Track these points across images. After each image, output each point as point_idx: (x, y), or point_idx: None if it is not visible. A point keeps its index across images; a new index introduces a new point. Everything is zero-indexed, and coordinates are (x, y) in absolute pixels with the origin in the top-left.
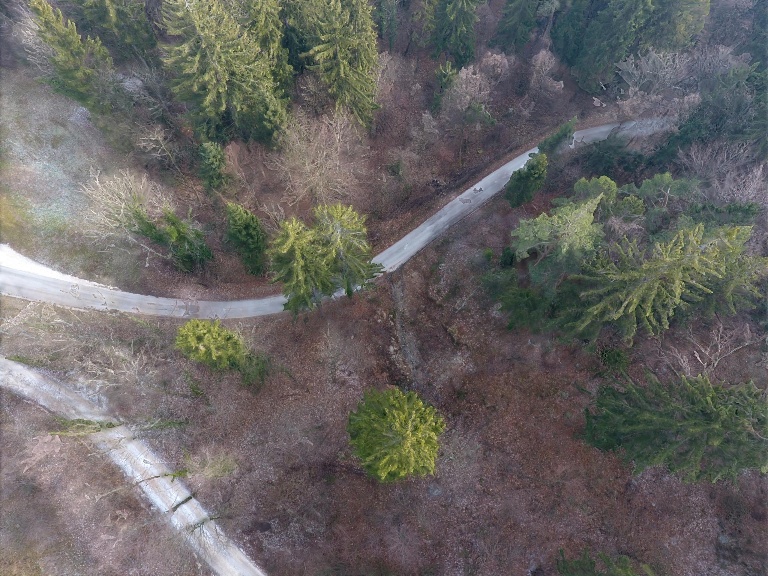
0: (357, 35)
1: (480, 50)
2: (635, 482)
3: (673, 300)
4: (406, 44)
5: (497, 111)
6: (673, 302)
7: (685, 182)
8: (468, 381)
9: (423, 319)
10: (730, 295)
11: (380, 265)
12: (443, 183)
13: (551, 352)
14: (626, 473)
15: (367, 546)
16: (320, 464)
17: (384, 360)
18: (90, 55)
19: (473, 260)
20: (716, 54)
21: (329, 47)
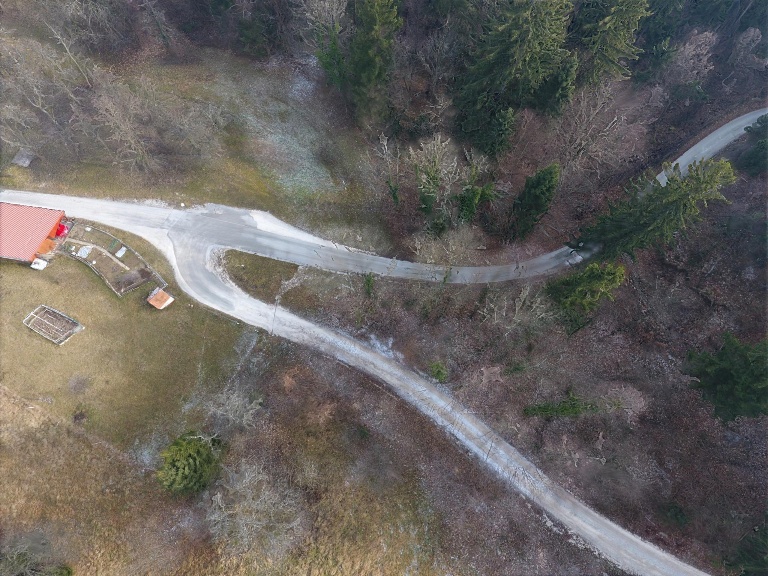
0: (640, 7)
1: (682, 29)
2: None
3: None
4: None
5: None
6: None
7: None
8: None
9: (663, 284)
10: None
11: None
12: (643, 158)
13: None
14: None
15: (687, 487)
16: (611, 415)
17: None
18: None
19: (730, 224)
20: None
21: (611, 19)
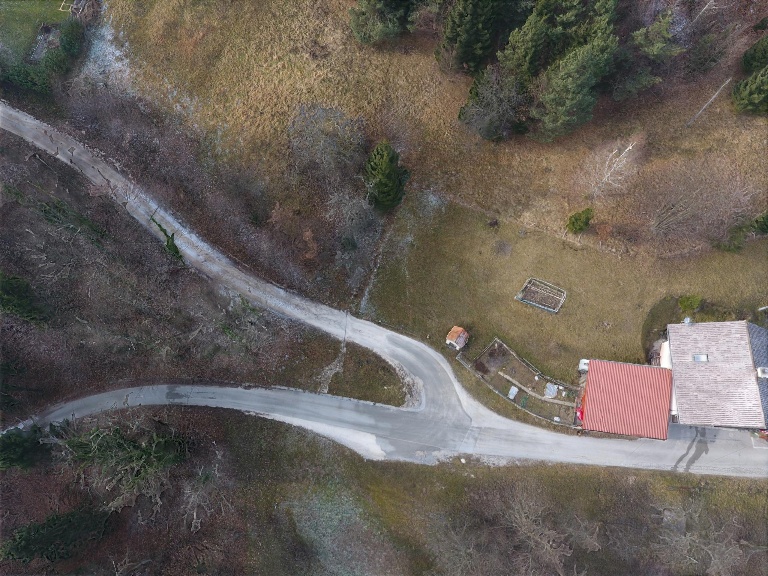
0: None
1: None
2: None
3: None
4: None
5: None
6: None
7: None
8: None
9: None
10: None
11: None
12: None
13: None
14: None
15: None
16: None
17: None
18: None
19: None
20: None
21: None
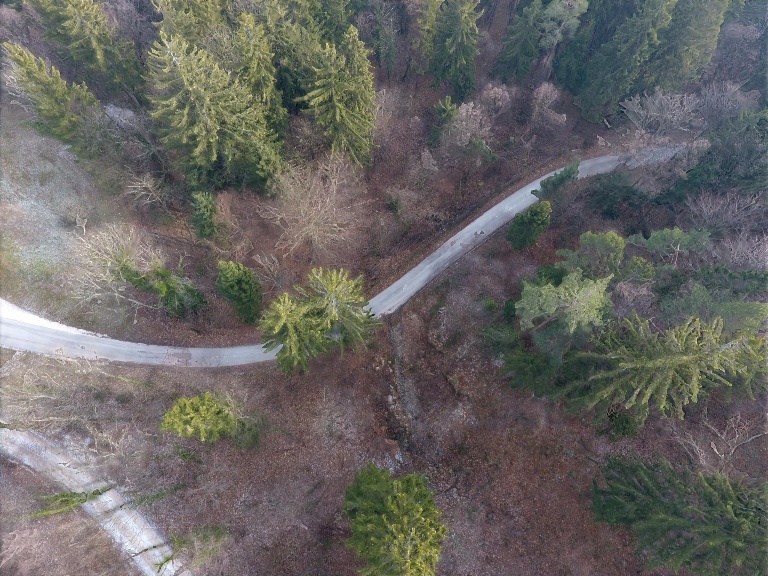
0: (353, 79)
1: (480, 81)
2: (644, 551)
3: (688, 387)
4: (404, 68)
5: (498, 140)
6: (688, 390)
7: (694, 233)
8: (470, 435)
9: (423, 366)
10: (748, 382)
11: (378, 321)
12: (443, 218)
13: (556, 407)
14: (635, 541)
15: None
16: (316, 526)
17: (383, 411)
18: (76, 101)
19: (474, 308)
20: (724, 90)
21: (324, 91)
